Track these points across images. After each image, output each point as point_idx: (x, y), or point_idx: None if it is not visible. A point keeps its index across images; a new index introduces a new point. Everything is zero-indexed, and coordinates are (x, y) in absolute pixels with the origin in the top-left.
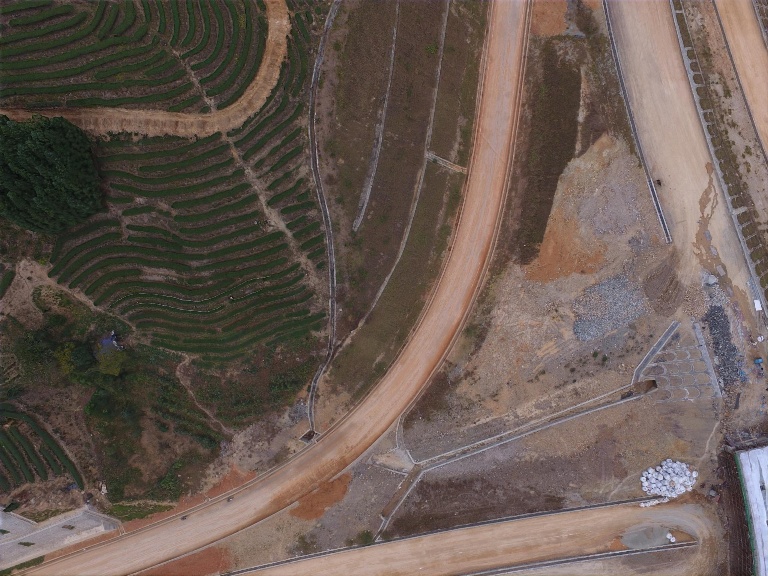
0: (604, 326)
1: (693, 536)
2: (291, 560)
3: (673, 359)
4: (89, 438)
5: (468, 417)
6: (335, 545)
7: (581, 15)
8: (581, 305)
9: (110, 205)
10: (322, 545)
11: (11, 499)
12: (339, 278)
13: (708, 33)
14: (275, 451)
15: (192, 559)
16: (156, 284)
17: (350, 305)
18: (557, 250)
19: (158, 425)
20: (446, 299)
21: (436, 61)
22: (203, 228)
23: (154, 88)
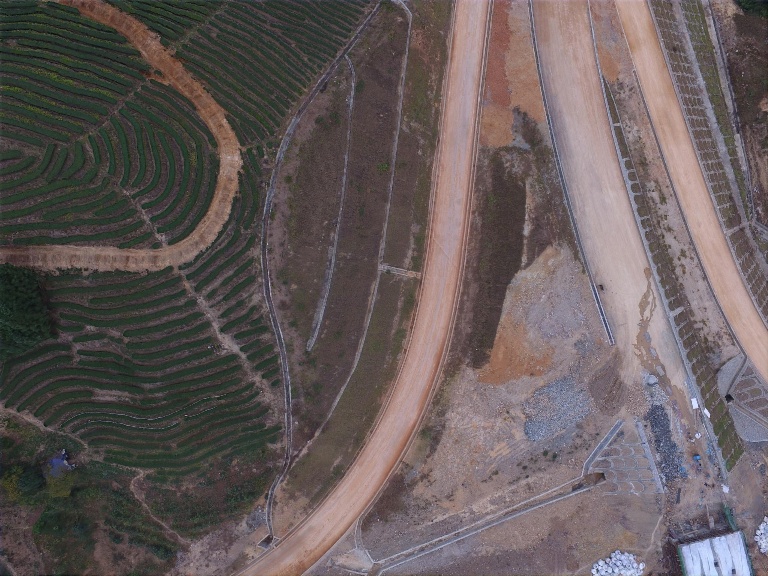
0: (553, 427)
1: None
2: None
3: (619, 454)
4: (39, 556)
5: (425, 516)
6: None
7: (526, 128)
8: (531, 407)
9: (60, 331)
10: None
11: None
12: (294, 393)
13: (644, 144)
14: (233, 558)
15: None
16: (108, 405)
17: (306, 418)
18: (507, 354)
19: (112, 537)
20: (402, 400)
21: (388, 177)
22: (156, 354)
23: (104, 226)
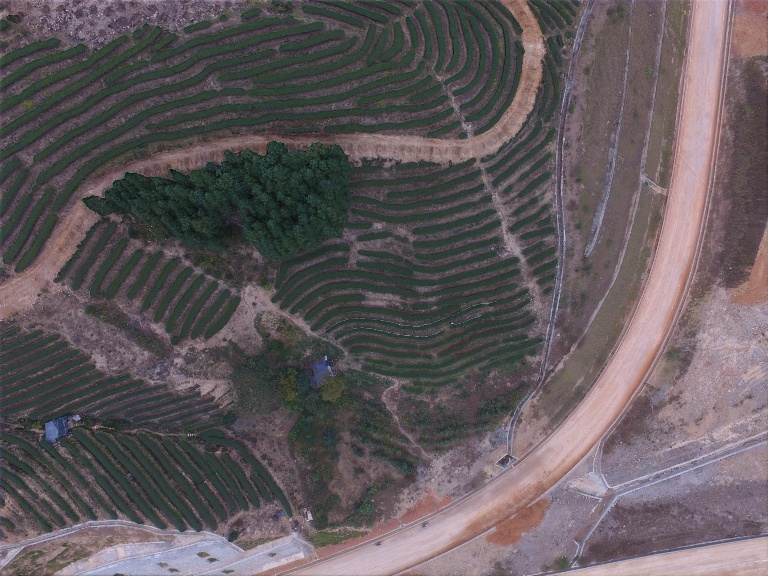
0: None
1: None
2: None
3: None
4: (292, 464)
5: (666, 441)
6: (531, 571)
7: None
8: None
9: (343, 230)
10: (518, 571)
11: (229, 528)
12: (562, 303)
13: None
14: (472, 476)
15: None
16: (379, 309)
17: (569, 330)
18: (765, 273)
19: (355, 450)
20: (645, 322)
21: (652, 82)
22: (441, 254)
23: (414, 114)
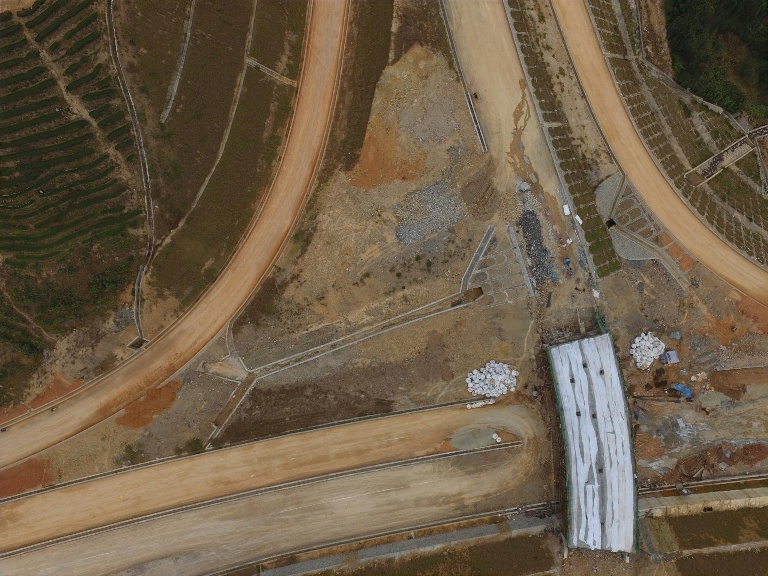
0: (424, 229)
1: (518, 436)
2: (118, 471)
3: (494, 264)
4: None
5: (299, 323)
6: (164, 454)
7: None
8: (403, 210)
9: None
10: (150, 454)
11: None
12: (152, 173)
13: None
14: (101, 358)
15: (12, 472)
16: None
17: (166, 201)
18: (379, 157)
19: None
20: (277, 207)
21: None
22: (1, 113)
23: None
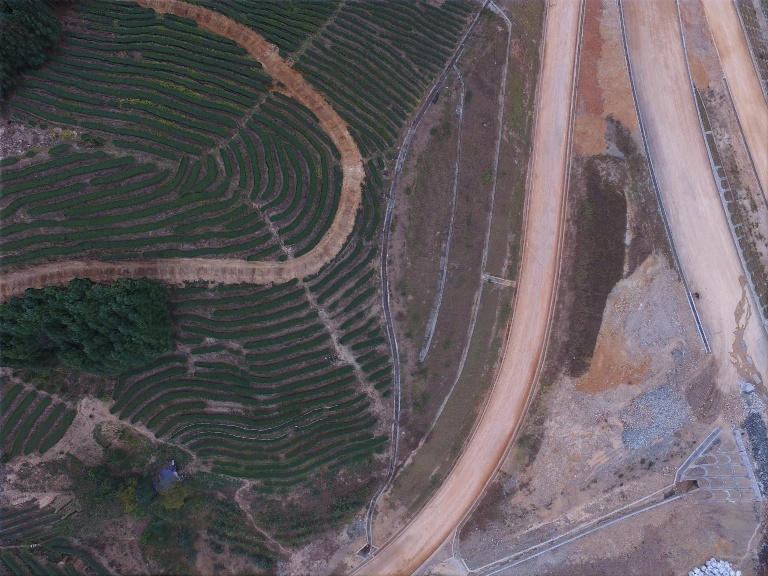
0: (651, 435)
1: None
2: None
3: (714, 462)
4: (145, 567)
5: (522, 525)
6: None
7: (620, 136)
8: (629, 415)
9: (178, 343)
10: None
11: None
12: (403, 404)
13: (735, 152)
14: (333, 568)
15: None
16: (221, 416)
17: (413, 428)
18: (605, 363)
19: (214, 547)
20: (498, 409)
21: (490, 187)
22: (274, 366)
23: (233, 239)
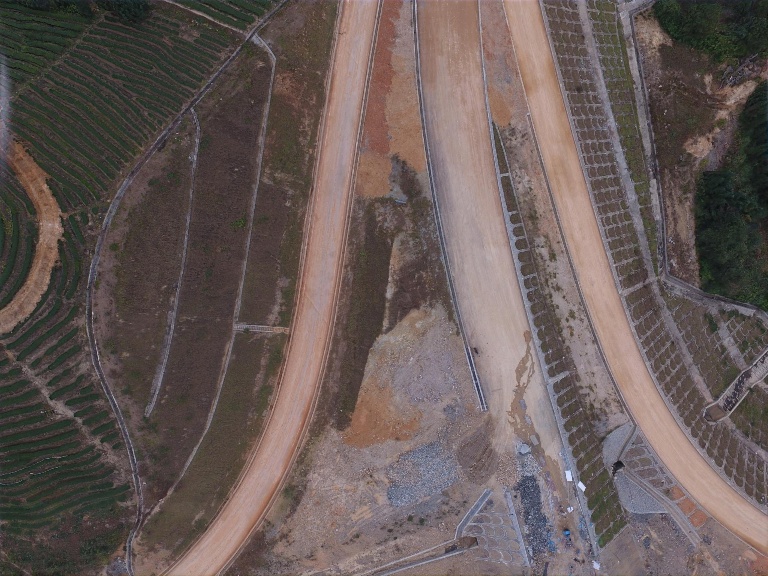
0: (417, 493)
1: None
2: None
3: (489, 522)
4: None
5: (288, 573)
6: None
7: (405, 177)
8: (395, 472)
9: None
10: None
11: None
12: (139, 456)
13: (535, 196)
14: None
15: None
16: None
17: (153, 479)
18: (372, 417)
19: None
20: (267, 457)
21: (245, 233)
22: None
23: None
